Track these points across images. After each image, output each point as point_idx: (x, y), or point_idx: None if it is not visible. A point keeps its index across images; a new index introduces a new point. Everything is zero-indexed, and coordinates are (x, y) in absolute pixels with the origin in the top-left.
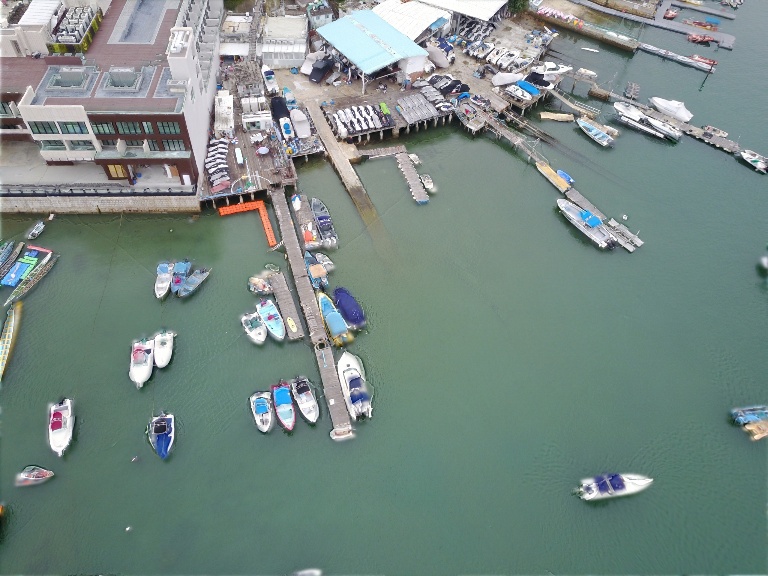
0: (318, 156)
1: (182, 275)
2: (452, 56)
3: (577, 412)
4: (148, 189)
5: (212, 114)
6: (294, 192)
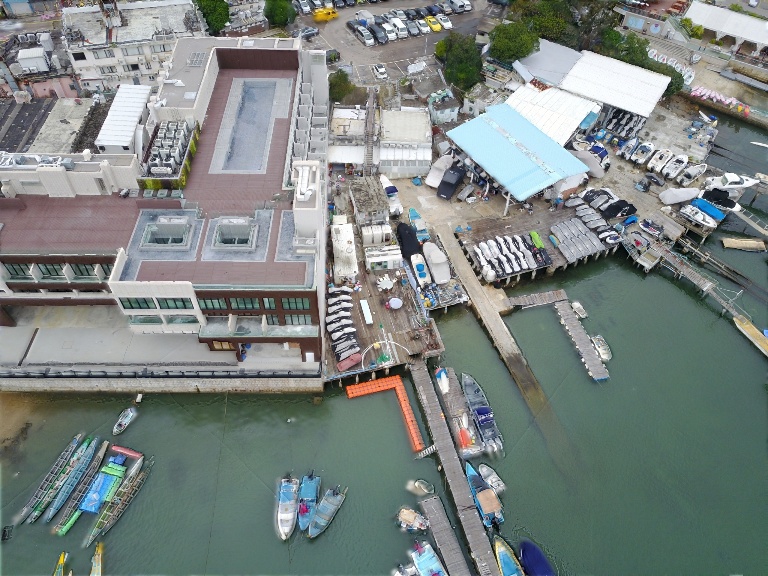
0: (458, 304)
1: (312, 501)
2: (606, 162)
3: None
4: (263, 371)
5: (328, 249)
6: (437, 362)
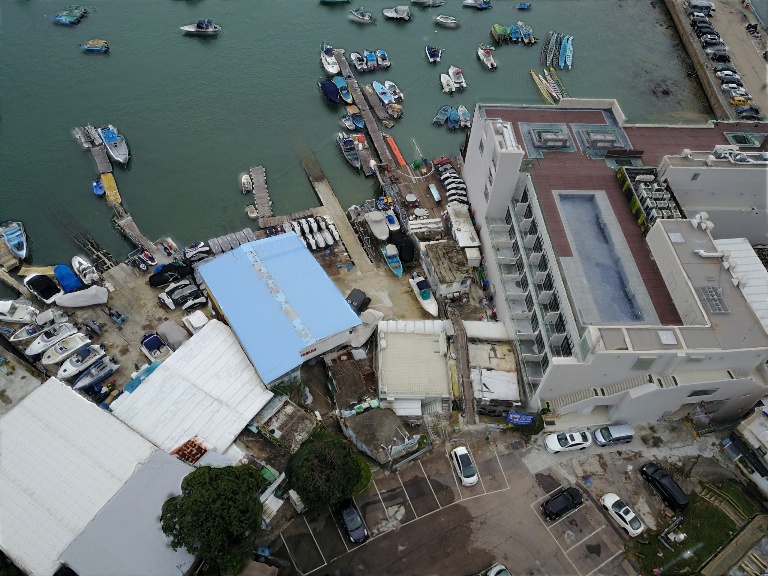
0: None
1: None
2: None
3: None
4: None
5: (477, 232)
6: None
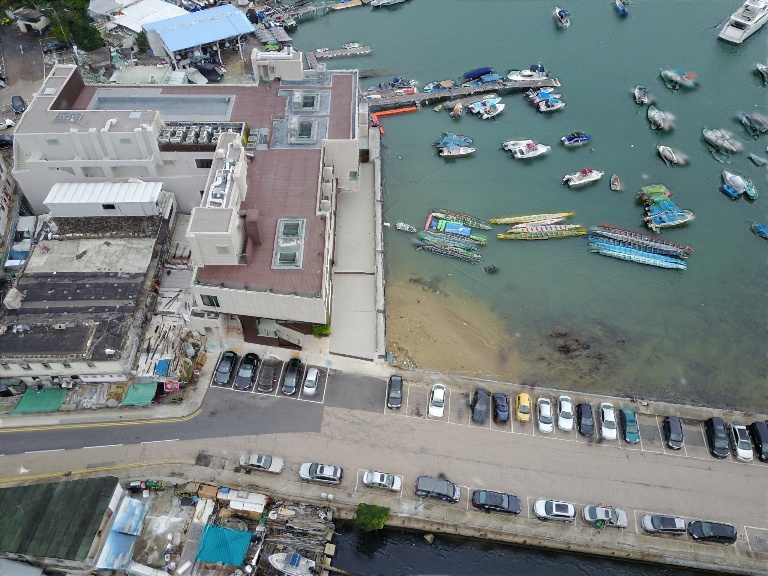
0: None
1: None
2: None
3: (521, 24)
4: None
5: None
6: None
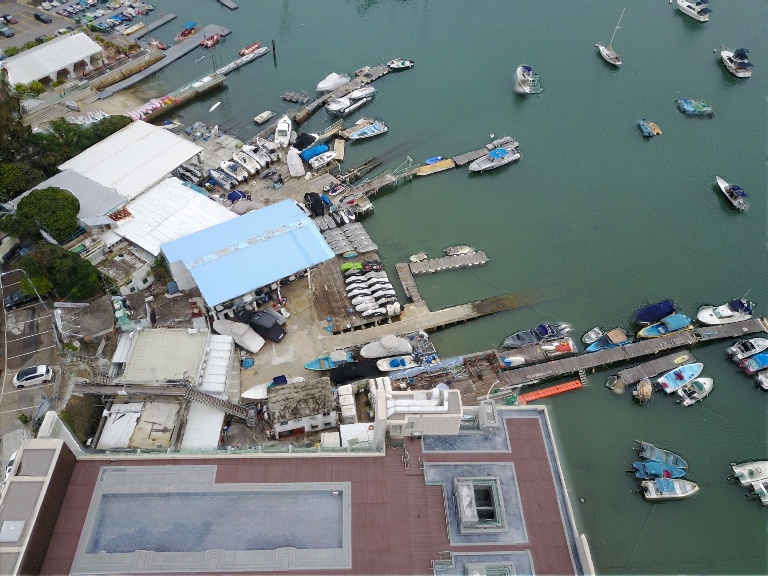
0: None
1: None
2: None
3: (674, 202)
4: None
5: None
6: None
